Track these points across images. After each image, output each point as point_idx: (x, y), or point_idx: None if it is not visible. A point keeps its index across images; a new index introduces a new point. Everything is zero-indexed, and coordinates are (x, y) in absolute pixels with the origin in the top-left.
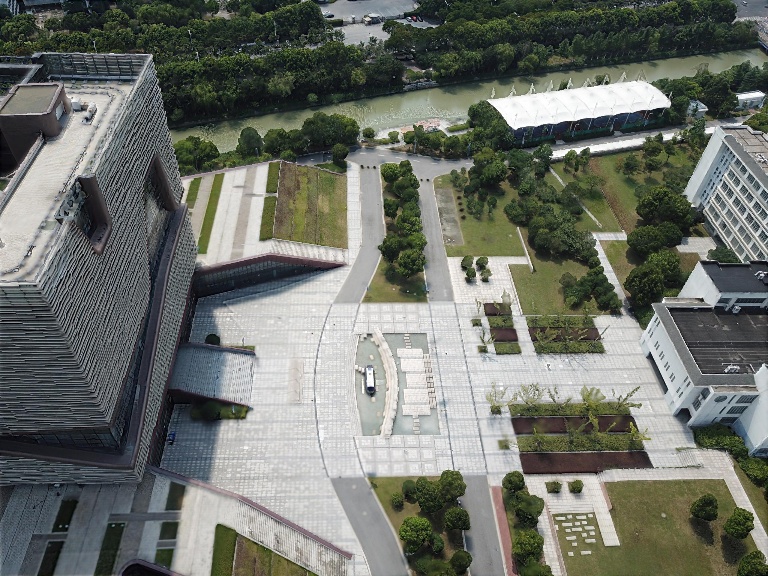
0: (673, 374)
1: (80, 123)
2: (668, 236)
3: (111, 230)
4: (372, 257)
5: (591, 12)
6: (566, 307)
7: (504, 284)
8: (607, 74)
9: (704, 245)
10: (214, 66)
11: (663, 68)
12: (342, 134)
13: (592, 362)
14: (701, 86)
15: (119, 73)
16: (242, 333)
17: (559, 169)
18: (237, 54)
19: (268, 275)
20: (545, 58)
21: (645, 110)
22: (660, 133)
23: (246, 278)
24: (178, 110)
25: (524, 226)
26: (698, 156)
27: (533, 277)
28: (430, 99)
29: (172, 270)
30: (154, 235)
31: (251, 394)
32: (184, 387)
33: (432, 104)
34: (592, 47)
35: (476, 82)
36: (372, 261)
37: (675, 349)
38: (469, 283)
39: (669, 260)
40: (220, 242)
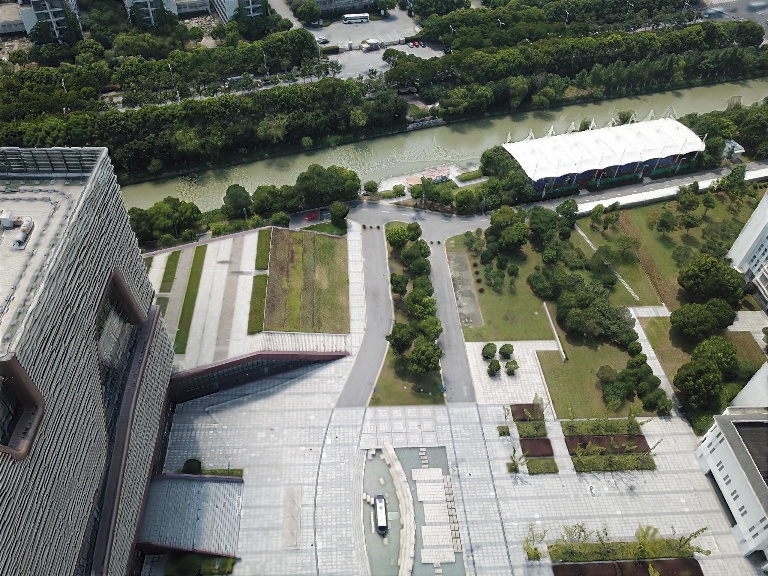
0: (744, 507)
1: (10, 248)
2: (719, 317)
3: (43, 411)
4: (379, 344)
5: (610, 38)
6: (608, 412)
7: (533, 378)
8: (632, 111)
9: (756, 321)
10: (196, 109)
11: (688, 98)
12: (341, 189)
13: (642, 483)
14: (736, 124)
15: (66, 169)
16: (228, 451)
17: (585, 226)
18: (223, 90)
19: (258, 373)
20: (561, 90)
21: (677, 154)
22: (696, 182)
23: (232, 378)
24: (156, 160)
25: (551, 300)
26: (740, 209)
27: (565, 367)
28: (436, 138)
29: (139, 401)
30: (115, 364)
31: (238, 538)
32: (156, 537)
33: (438, 143)
34: (612, 77)
35: (486, 118)
36: (379, 350)
37: (748, 481)
38: (492, 377)
39: (725, 351)
40: (201, 337)
